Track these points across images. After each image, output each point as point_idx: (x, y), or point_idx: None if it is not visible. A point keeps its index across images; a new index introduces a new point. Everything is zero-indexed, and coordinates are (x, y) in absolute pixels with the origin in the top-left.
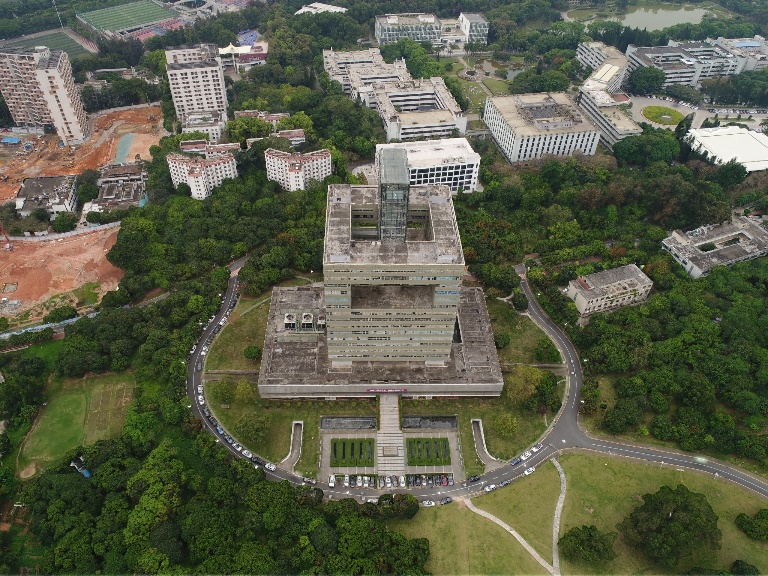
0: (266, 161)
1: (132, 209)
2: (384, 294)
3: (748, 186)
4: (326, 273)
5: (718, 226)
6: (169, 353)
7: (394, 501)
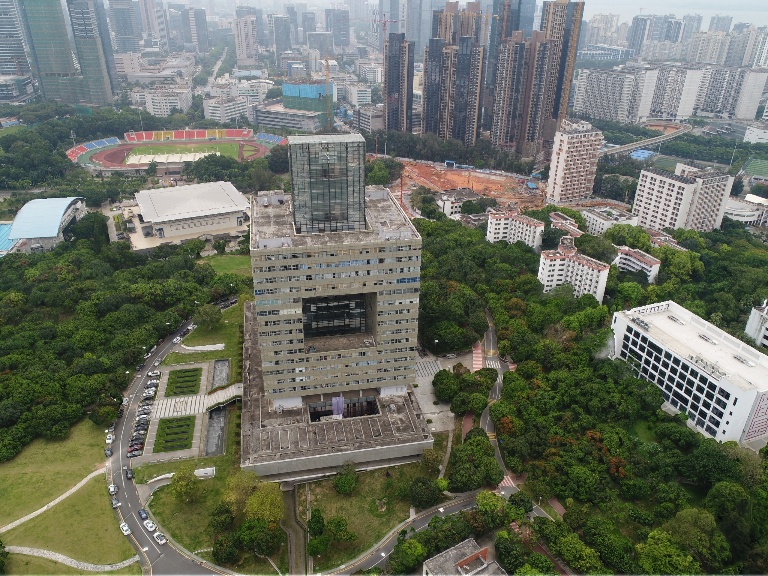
0: None
1: (457, 224)
2: None
3: None
4: None
5: None
6: None
7: None
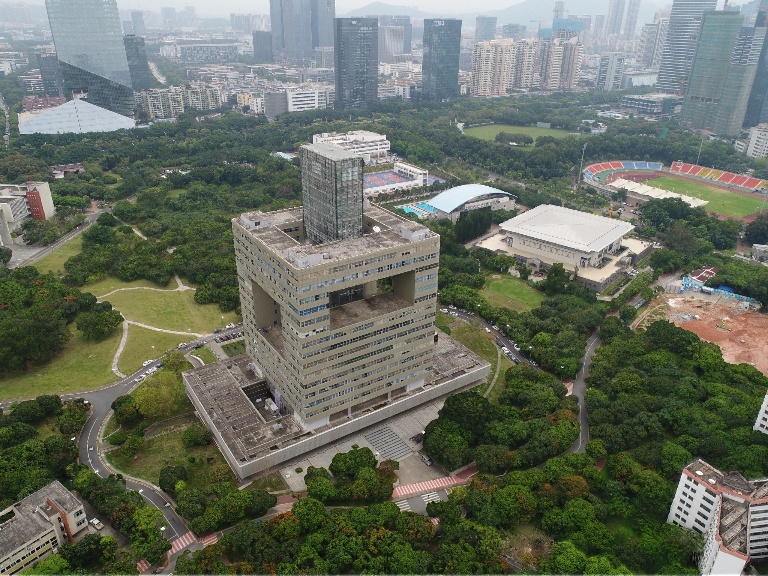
0: None
1: None
2: None
3: None
4: None
5: None
6: None
7: None
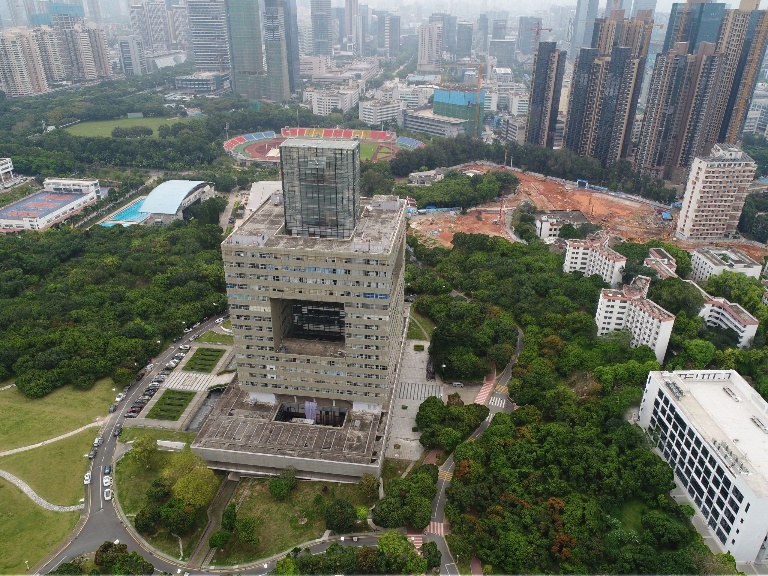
0: None
1: (543, 247)
2: None
3: None
4: None
5: None
6: None
7: None
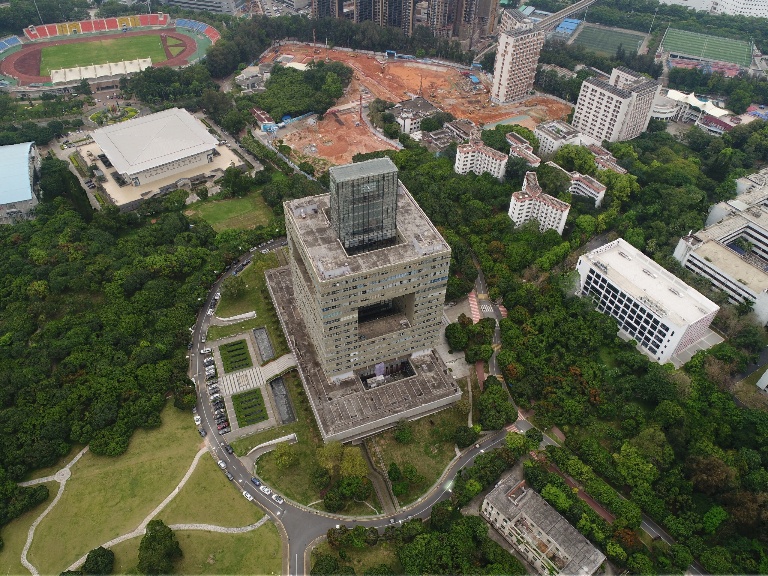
0: None
1: (423, 149)
2: None
3: None
4: None
5: None
6: None
7: None
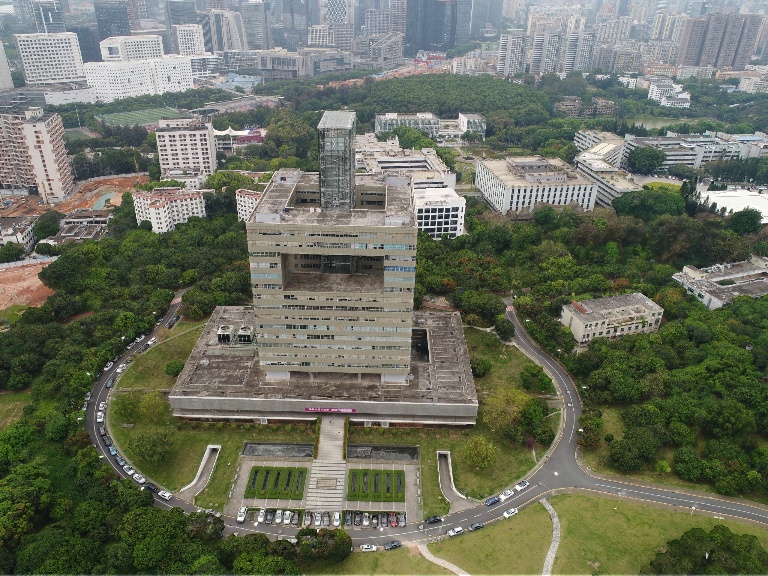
0: (237, 201)
1: None
2: (327, 280)
3: (766, 238)
4: (250, 235)
5: (736, 265)
6: (78, 368)
7: (318, 537)
